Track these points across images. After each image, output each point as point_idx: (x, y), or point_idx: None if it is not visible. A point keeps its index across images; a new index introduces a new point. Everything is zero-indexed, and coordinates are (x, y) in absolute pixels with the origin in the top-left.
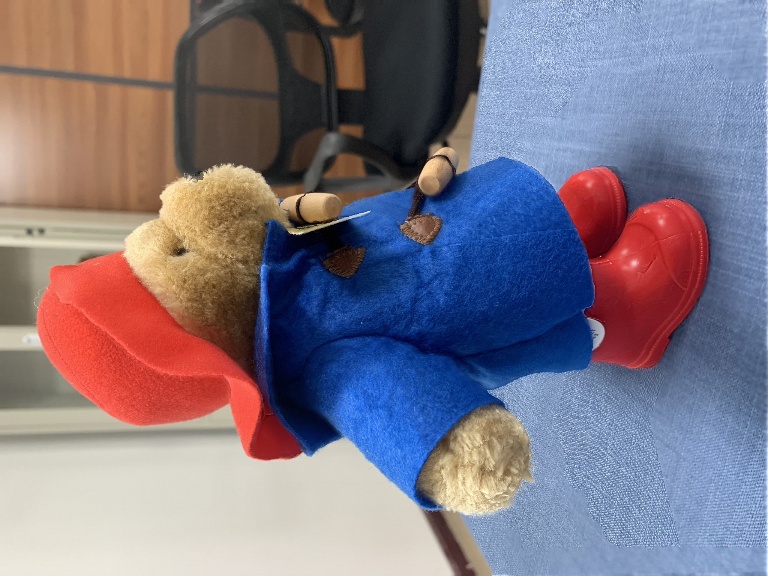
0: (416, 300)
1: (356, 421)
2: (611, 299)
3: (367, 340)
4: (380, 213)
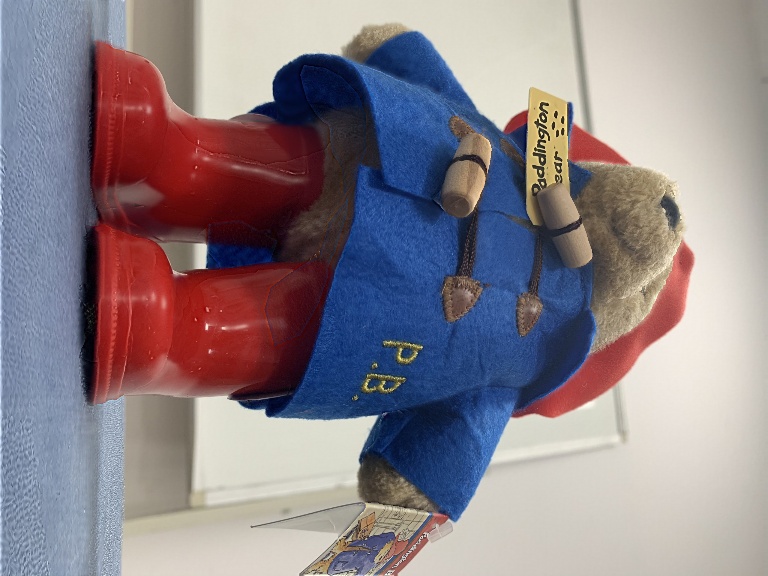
0: None
1: None
2: None
3: None
4: (504, 173)
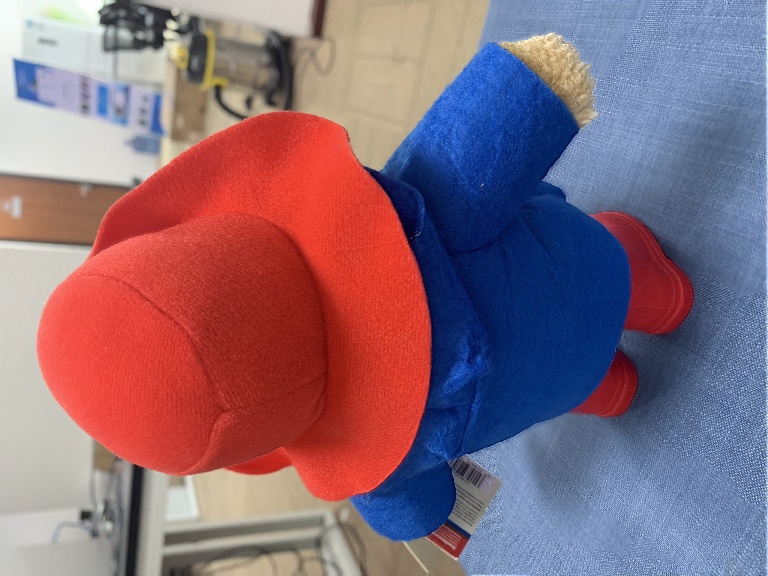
0: None
1: (432, 116)
2: None
3: None
4: None
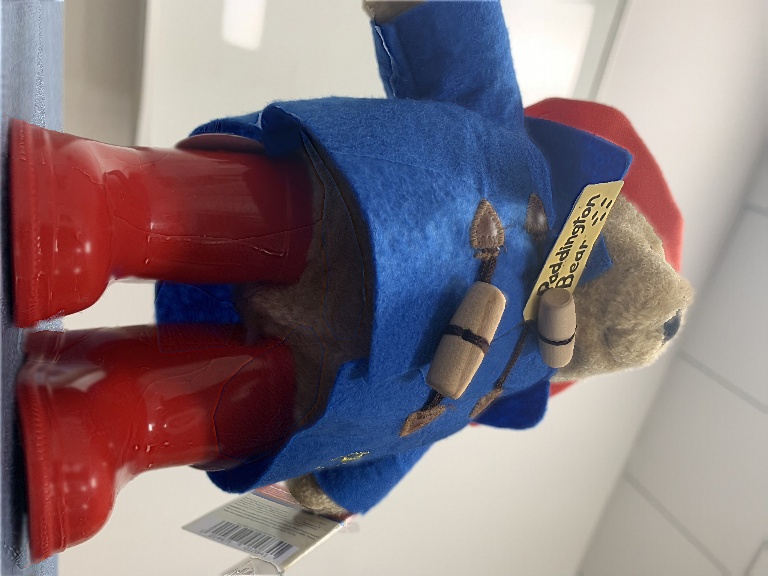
0: (488, 135)
1: None
2: (178, 161)
3: (509, 124)
4: (514, 282)
